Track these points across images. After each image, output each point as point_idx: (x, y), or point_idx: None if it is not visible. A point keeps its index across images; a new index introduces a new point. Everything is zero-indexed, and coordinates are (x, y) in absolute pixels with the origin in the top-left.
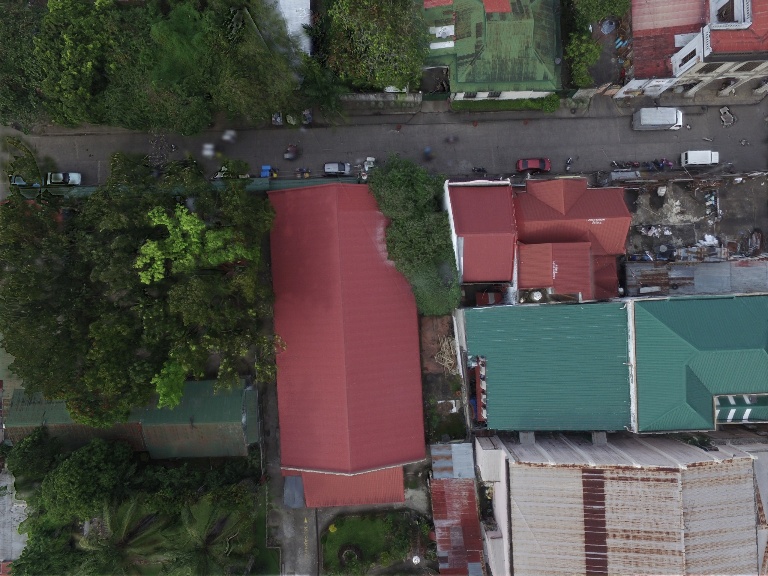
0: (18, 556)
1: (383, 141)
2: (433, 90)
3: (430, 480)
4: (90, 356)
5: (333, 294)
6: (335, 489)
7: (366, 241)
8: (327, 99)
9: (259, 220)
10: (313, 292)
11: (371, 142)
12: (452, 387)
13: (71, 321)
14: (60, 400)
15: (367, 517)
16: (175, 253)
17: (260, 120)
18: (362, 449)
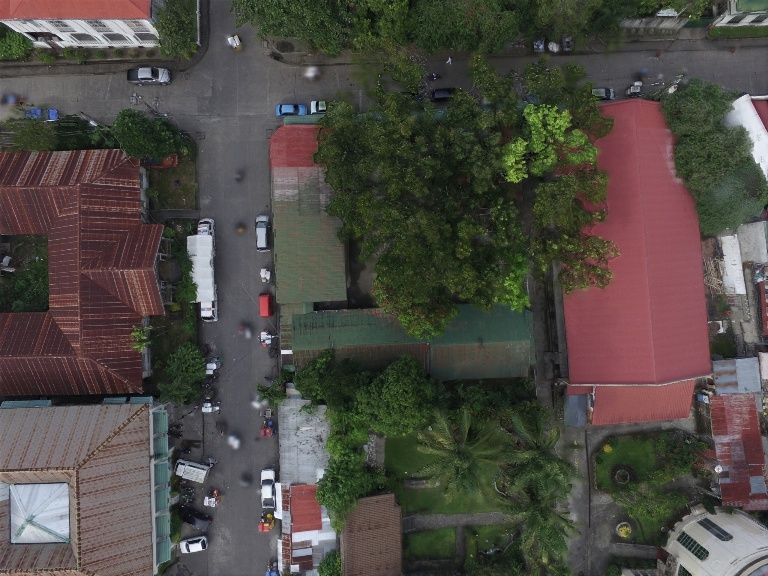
0: (306, 479)
1: (643, 68)
2: (695, 16)
3: (709, 397)
4: (460, 255)
5: (632, 209)
6: (624, 405)
7: (658, 158)
8: (614, 20)
9: (599, 125)
10: (608, 209)
11: (631, 69)
12: (719, 308)
13: (443, 220)
14: (342, 324)
15: (639, 437)
16: (535, 154)
17: (521, 48)
18: (663, 361)
